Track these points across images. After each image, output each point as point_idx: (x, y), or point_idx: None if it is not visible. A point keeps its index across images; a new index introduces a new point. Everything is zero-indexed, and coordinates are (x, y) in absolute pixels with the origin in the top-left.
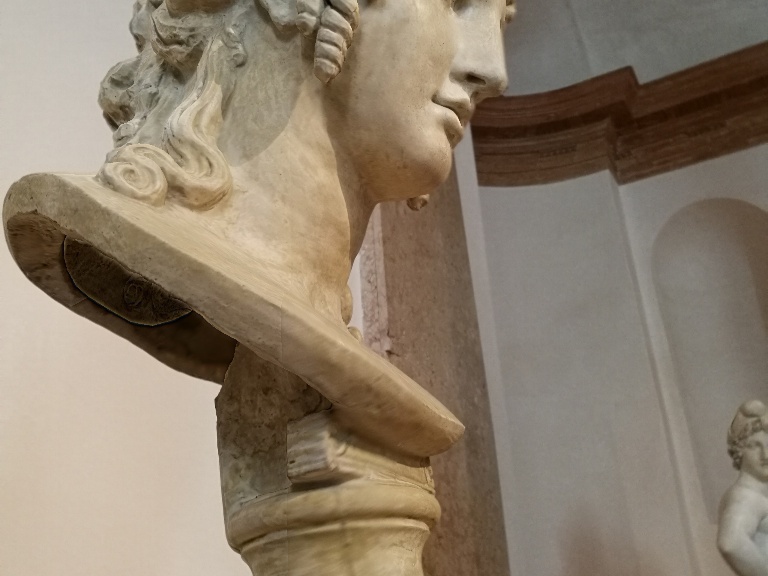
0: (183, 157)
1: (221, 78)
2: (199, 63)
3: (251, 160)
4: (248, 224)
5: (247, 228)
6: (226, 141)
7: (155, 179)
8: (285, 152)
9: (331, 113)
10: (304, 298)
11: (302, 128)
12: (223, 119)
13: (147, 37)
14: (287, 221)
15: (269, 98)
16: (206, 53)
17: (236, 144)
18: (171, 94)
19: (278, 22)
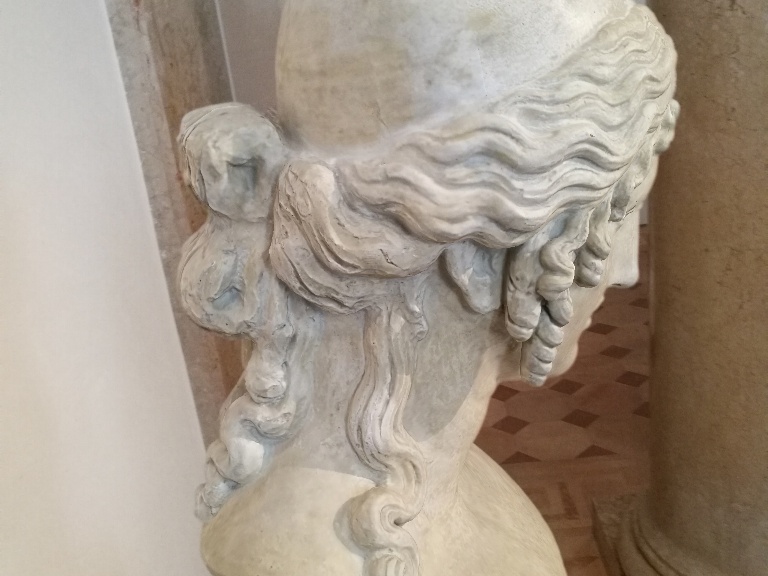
0: (388, 467)
1: (409, 366)
2: (376, 341)
3: (437, 434)
4: (434, 487)
5: (434, 491)
6: (411, 420)
7: (414, 554)
8: (466, 417)
9: (506, 369)
10: (469, 514)
11: (480, 390)
12: (407, 399)
13: (235, 218)
14: (458, 463)
15: (454, 373)
16: (384, 331)
17: (422, 422)
18: (310, 331)
19: (479, 312)
